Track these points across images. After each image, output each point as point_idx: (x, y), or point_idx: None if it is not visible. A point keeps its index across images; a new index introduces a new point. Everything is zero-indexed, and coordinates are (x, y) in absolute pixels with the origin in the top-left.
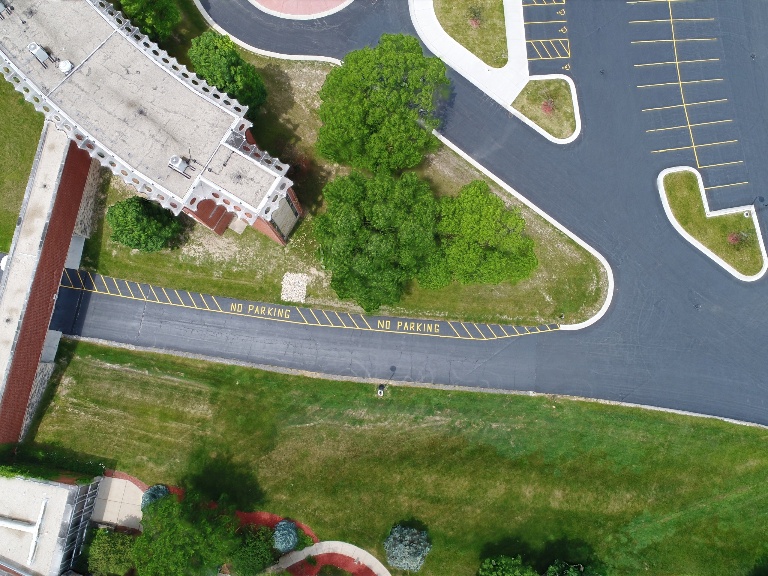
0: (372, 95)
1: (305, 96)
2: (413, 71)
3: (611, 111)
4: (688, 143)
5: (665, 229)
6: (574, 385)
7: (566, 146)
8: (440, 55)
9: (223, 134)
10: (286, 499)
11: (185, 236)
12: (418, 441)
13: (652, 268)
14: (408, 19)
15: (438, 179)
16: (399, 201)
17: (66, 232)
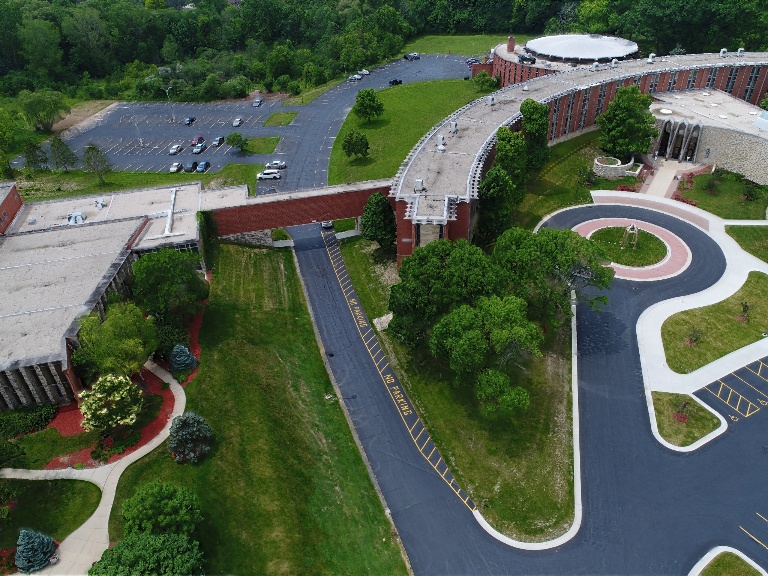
0: None
1: None
2: None
3: (738, 471)
4: None
5: None
6: (419, 550)
7: (661, 445)
8: (639, 333)
9: None
10: (215, 358)
11: (387, 261)
12: (296, 430)
13: None
14: (645, 307)
15: (538, 365)
16: (474, 259)
17: (355, 211)
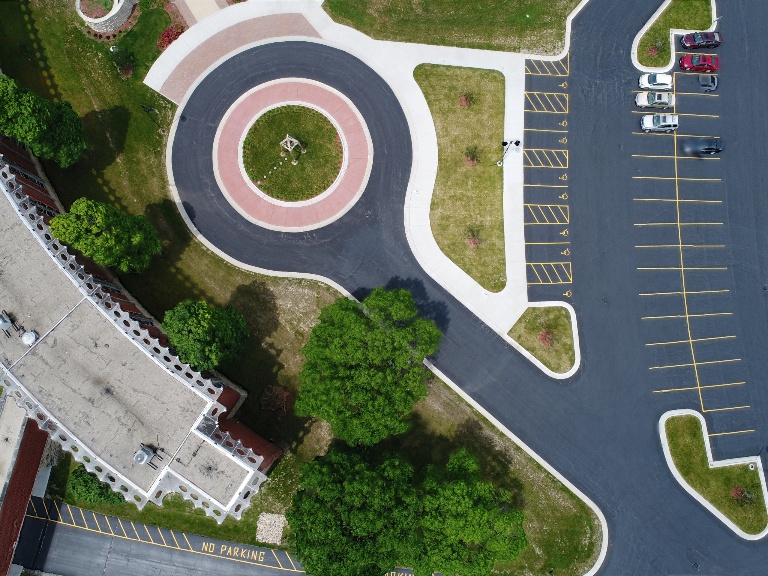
0: (356, 378)
1: (291, 317)
2: (401, 353)
3: (613, 344)
4: (693, 383)
5: (665, 479)
6: None
7: (564, 381)
8: (435, 276)
9: (194, 420)
10: None
11: None
12: None
13: (649, 522)
14: (403, 235)
15: (427, 414)
16: (379, 508)
17: (29, 476)
